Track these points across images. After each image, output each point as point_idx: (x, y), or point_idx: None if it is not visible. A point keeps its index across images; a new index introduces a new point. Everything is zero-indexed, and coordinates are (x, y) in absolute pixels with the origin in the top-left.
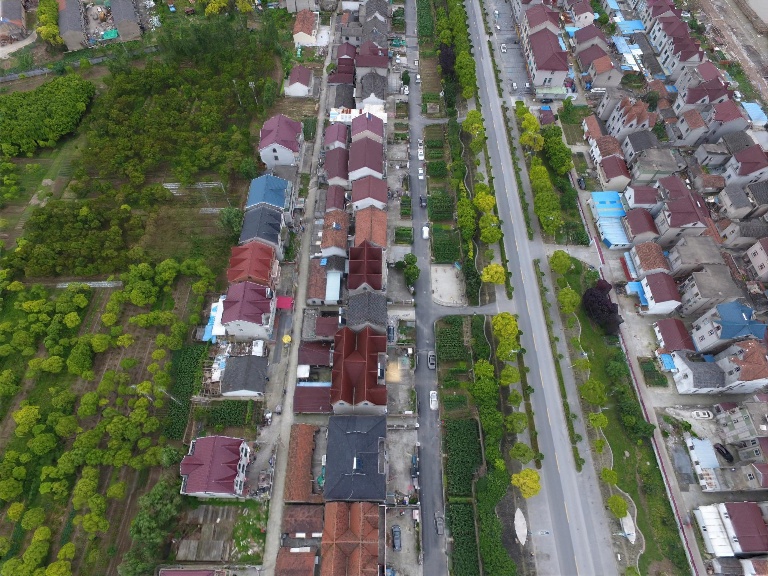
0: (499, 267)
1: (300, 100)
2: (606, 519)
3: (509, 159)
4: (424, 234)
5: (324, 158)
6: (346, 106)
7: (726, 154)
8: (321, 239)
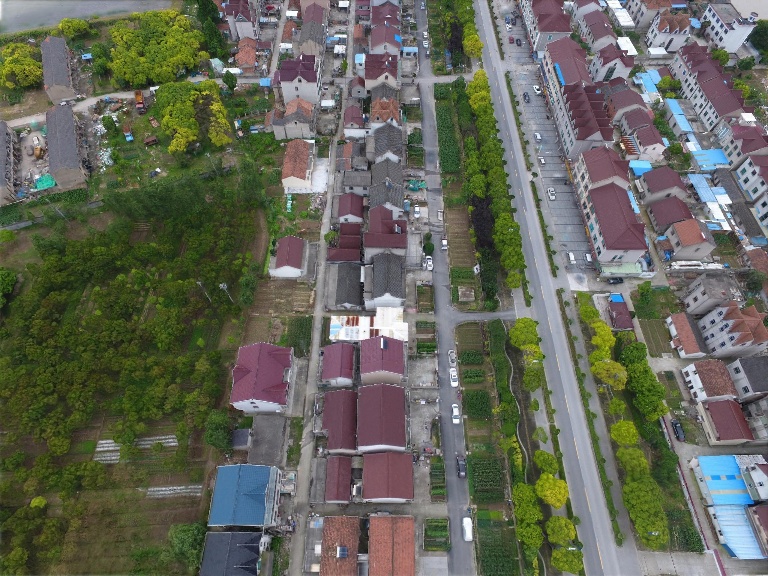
0: None
1: (290, 283)
2: None
3: (575, 387)
4: (466, 536)
5: (322, 399)
6: (351, 301)
7: None
8: (319, 562)
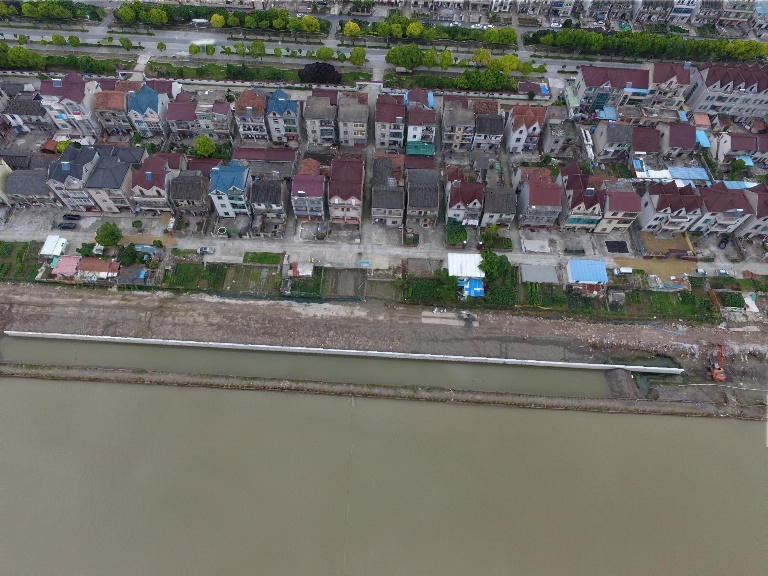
0: (354, 25)
1: None
2: (193, 57)
3: None
4: None
5: None
6: None
7: None
8: None
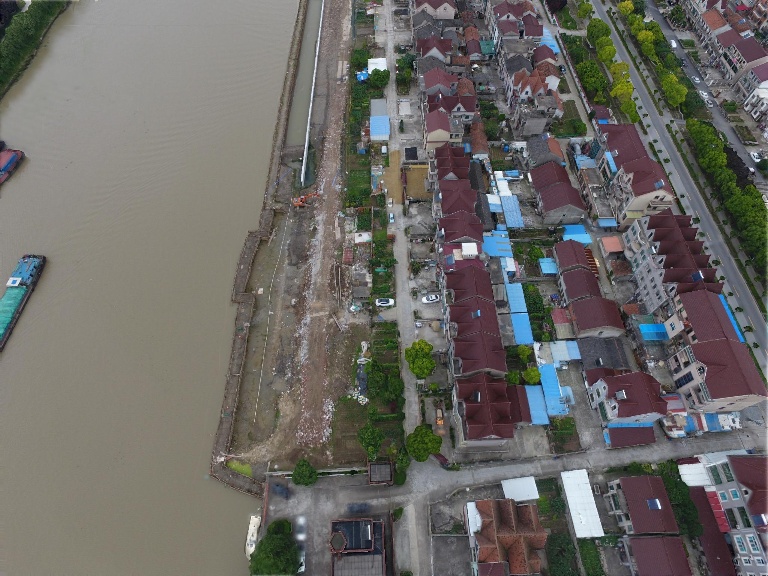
0: (626, 4)
1: None
2: None
3: None
4: None
5: None
6: None
7: (448, 65)
8: None
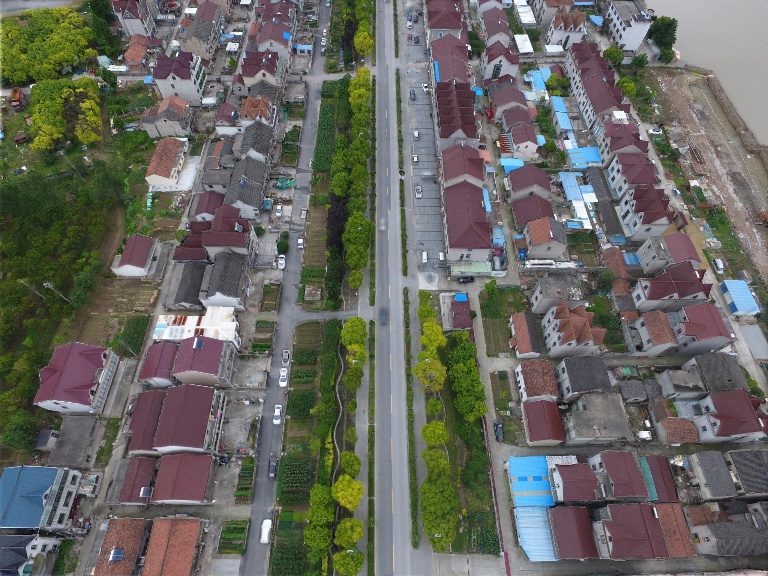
0: None
1: (136, 282)
2: None
3: (403, 387)
4: (261, 538)
5: None
6: (189, 300)
7: (700, 389)
8: None
